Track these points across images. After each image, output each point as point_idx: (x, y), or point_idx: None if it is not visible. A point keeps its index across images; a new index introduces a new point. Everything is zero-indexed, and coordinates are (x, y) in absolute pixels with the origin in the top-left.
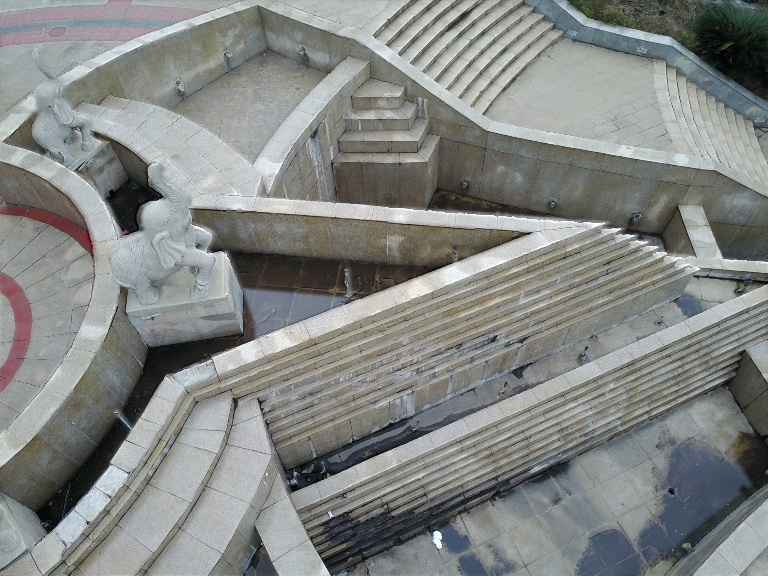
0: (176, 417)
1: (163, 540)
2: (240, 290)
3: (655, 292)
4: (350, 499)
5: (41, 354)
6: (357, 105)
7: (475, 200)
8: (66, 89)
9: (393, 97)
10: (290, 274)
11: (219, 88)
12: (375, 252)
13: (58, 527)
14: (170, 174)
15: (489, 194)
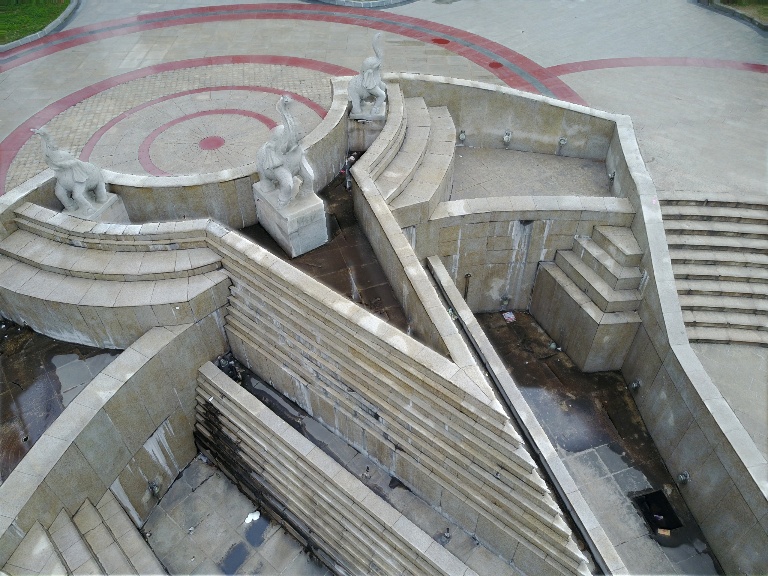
0: (188, 239)
1: (111, 274)
2: (324, 240)
3: (547, 567)
4: (224, 403)
5: None
6: (595, 237)
7: (634, 409)
8: (417, 82)
9: (622, 251)
10: (358, 260)
11: (535, 159)
12: (399, 291)
13: (100, 223)
14: (374, 151)
15: (647, 414)
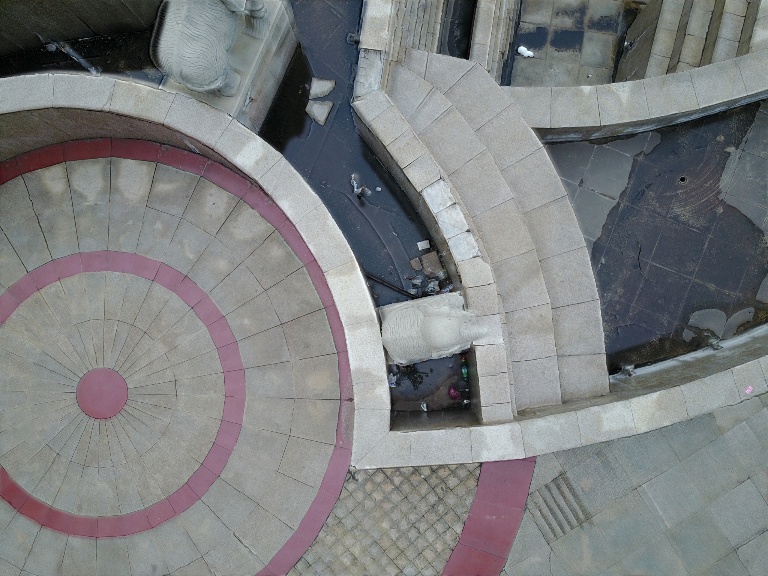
0: None
1: (507, 185)
2: None
3: None
4: None
5: (191, 256)
6: None
7: None
8: None
9: None
10: None
11: None
12: None
13: (456, 258)
14: None
15: None
